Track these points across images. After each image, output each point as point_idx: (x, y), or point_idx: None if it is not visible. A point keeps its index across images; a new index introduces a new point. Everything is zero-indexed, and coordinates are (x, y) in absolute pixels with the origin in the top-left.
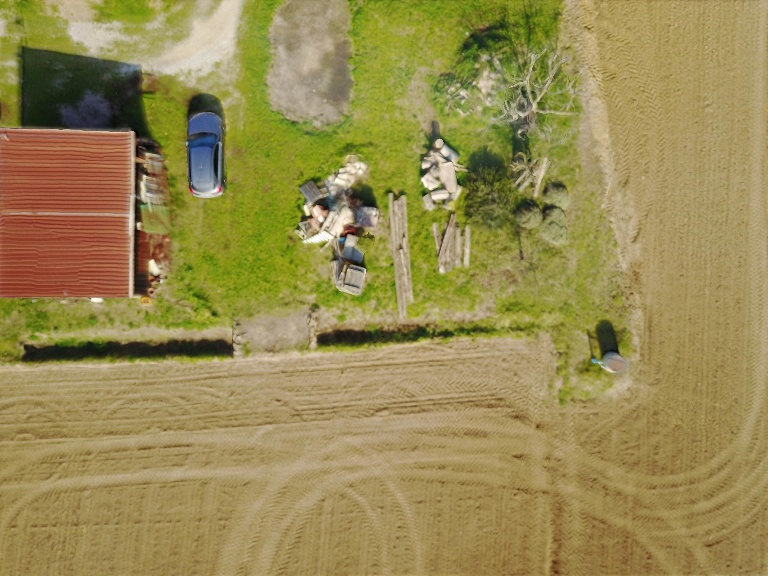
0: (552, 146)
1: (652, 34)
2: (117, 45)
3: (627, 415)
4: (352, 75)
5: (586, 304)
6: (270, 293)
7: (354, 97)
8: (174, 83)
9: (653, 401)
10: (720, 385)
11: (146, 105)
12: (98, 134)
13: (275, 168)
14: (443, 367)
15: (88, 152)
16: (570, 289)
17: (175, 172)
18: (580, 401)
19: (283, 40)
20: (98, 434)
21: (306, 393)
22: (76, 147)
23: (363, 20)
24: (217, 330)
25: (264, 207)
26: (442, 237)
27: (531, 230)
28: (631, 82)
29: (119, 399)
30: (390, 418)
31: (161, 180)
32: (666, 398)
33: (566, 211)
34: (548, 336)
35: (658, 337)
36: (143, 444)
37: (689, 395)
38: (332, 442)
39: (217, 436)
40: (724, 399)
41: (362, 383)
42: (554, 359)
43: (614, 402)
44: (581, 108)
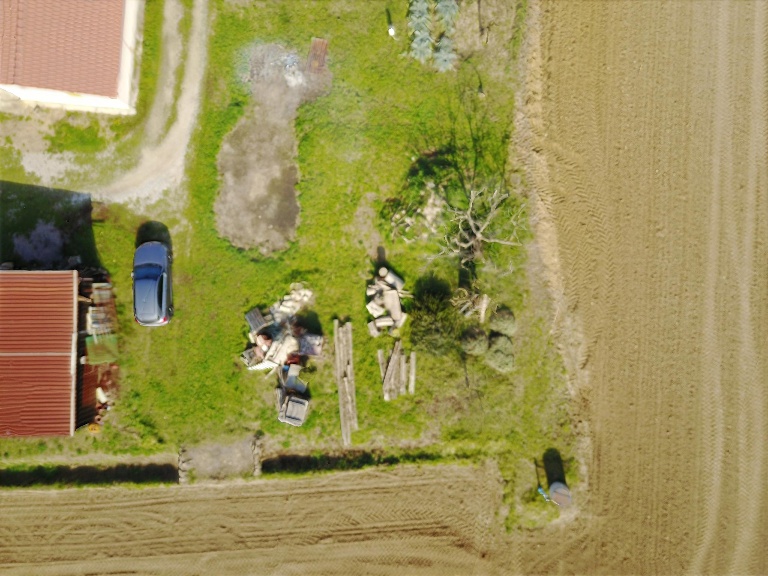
0: (499, 271)
1: (601, 157)
2: (67, 174)
3: (575, 546)
4: (298, 201)
5: (533, 432)
6: (216, 419)
7: (300, 223)
8: (122, 211)
9: (602, 533)
10: (670, 518)
11: (95, 233)
12: (41, 273)
13: (221, 294)
14: (388, 494)
15: (31, 291)
16: (517, 417)
17: (123, 299)
18: (527, 530)
19: (229, 166)
20: (47, 559)
21: (251, 520)
22: (19, 287)
23: (308, 146)
24: (164, 455)
25: (210, 333)
26: (387, 365)
27: (477, 357)
28: (580, 206)
29: (67, 524)
30: (334, 546)
31: (109, 308)
32: (615, 530)
33: (513, 337)
34: (495, 463)
35: (607, 467)
36: (90, 569)
37: (638, 528)
38: (276, 570)
39: (163, 562)
40: (674, 533)
41: (307, 510)
42: (501, 487)
43: (562, 532)
44: (529, 232)
